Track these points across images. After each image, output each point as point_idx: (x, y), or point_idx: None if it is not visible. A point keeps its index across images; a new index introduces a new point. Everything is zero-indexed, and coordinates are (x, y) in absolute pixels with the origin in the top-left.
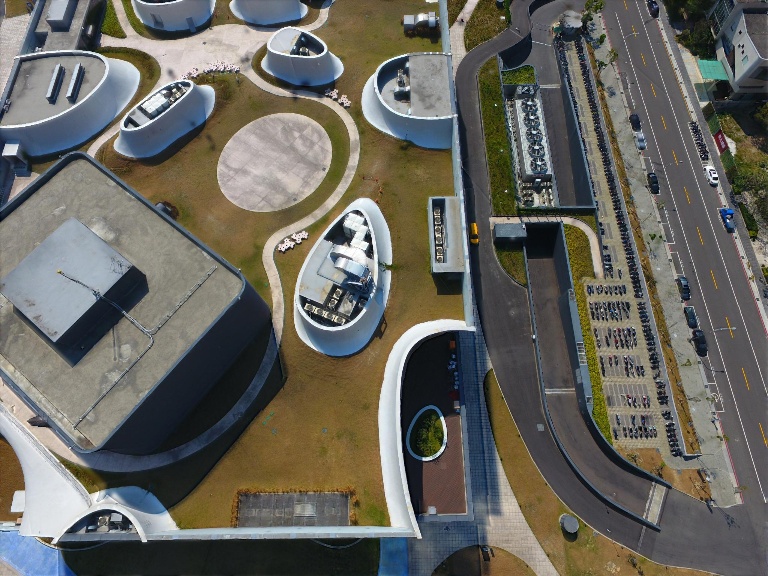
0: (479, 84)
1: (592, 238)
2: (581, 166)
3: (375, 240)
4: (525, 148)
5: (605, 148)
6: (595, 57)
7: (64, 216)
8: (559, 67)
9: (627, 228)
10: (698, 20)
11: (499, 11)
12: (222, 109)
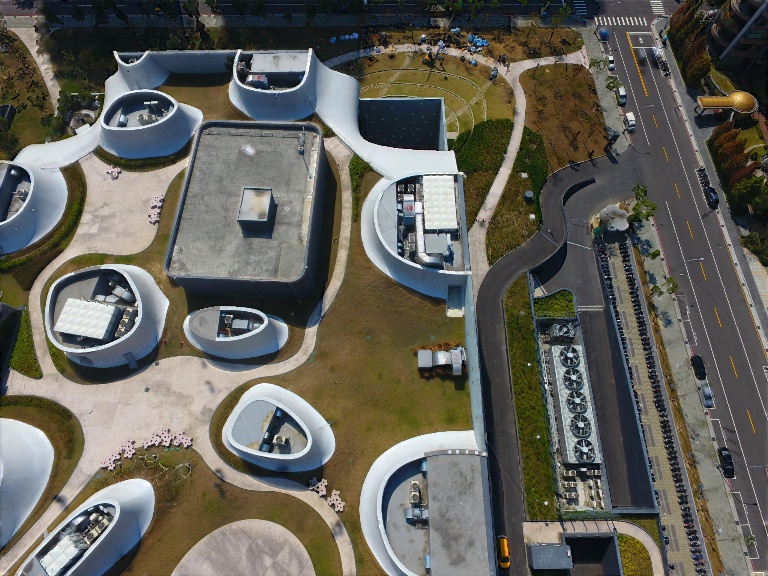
0: (506, 315)
1: (654, 554)
2: (635, 439)
3: None
4: (566, 421)
5: (663, 407)
6: (644, 267)
7: None
8: (601, 281)
9: (698, 537)
10: (767, 218)
11: (528, 206)
12: (164, 517)
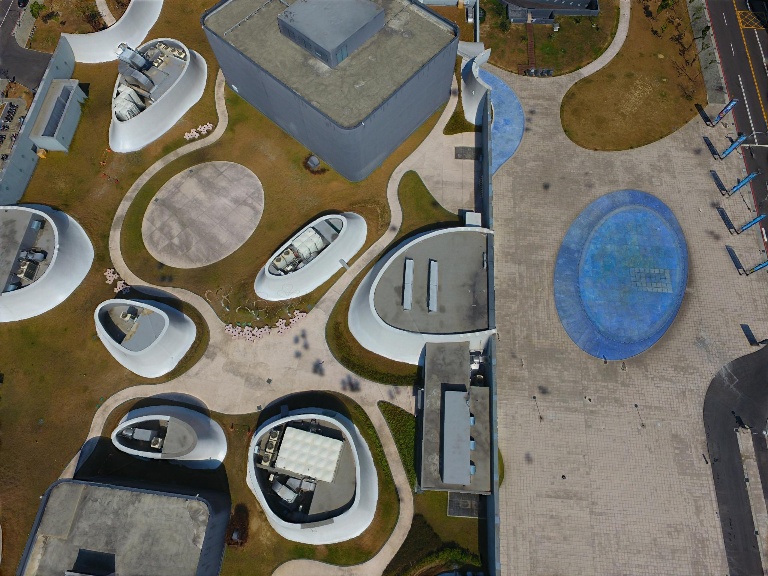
0: None
1: None
2: None
3: (113, 96)
4: None
5: None
6: None
7: (354, 79)
8: None
9: None
10: None
11: None
12: (252, 273)
